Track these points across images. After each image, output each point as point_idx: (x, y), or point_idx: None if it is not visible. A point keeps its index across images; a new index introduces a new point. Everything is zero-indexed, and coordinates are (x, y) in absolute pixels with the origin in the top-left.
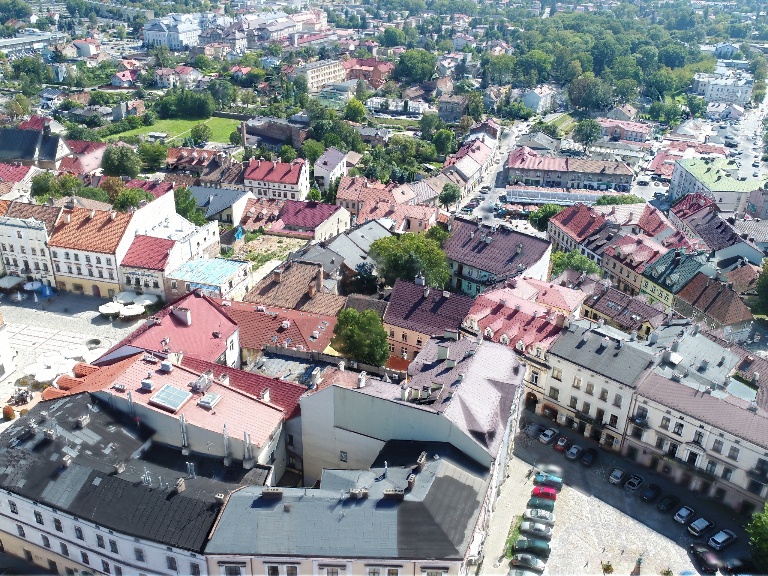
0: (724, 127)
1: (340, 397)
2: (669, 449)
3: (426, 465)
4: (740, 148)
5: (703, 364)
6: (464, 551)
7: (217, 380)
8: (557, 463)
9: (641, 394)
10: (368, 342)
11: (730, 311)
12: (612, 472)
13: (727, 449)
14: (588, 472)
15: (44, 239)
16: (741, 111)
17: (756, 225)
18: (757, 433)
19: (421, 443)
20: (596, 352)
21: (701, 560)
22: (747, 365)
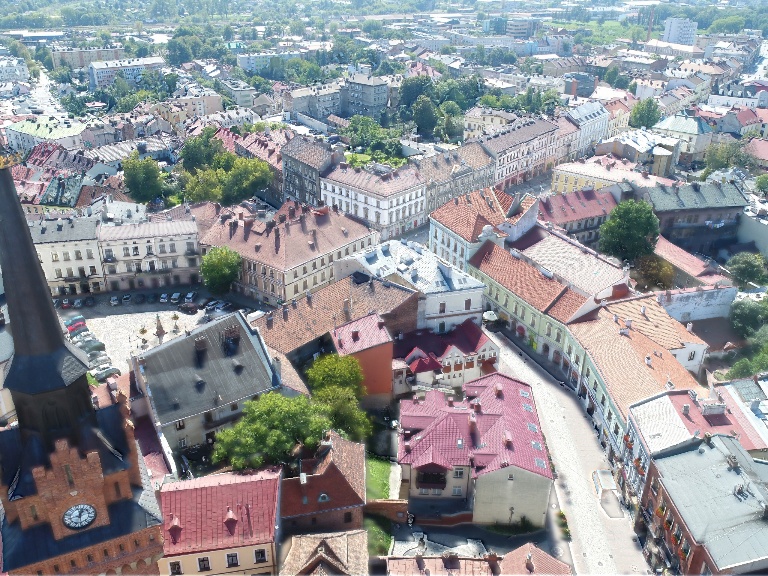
0: (23, 100)
1: None
2: (136, 268)
3: (2, 308)
4: (46, 114)
5: (128, 213)
6: (65, 329)
7: None
8: (71, 314)
9: (103, 241)
10: None
11: None
12: (110, 300)
13: (168, 247)
14: (95, 308)
15: None
16: (28, 86)
17: (99, 151)
18: (179, 230)
19: None
20: (58, 231)
21: (187, 309)
22: (149, 221)
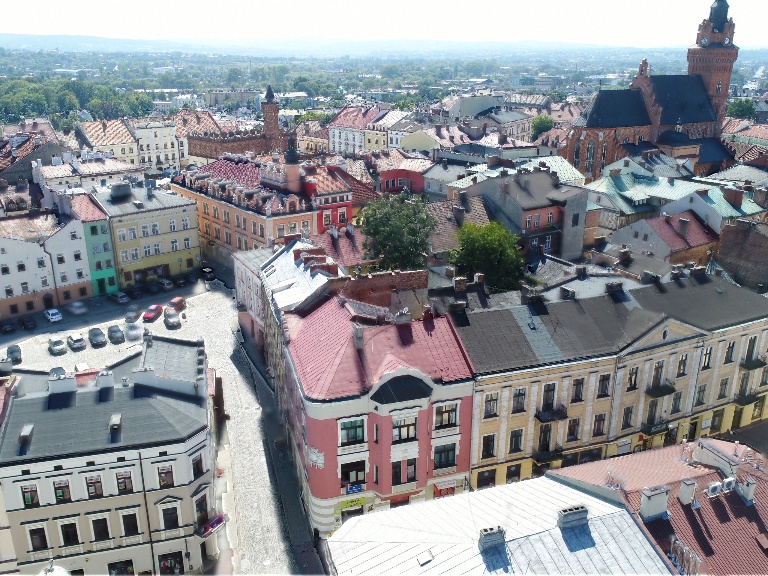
0: (225, 116)
1: (462, 102)
2: None
3: None
4: None
5: None
6: None
7: None
8: None
9: None
10: None
11: None
12: None
13: None
14: None
15: (175, 134)
16: (213, 111)
17: None
18: None
19: (486, 110)
20: None
21: None
22: None
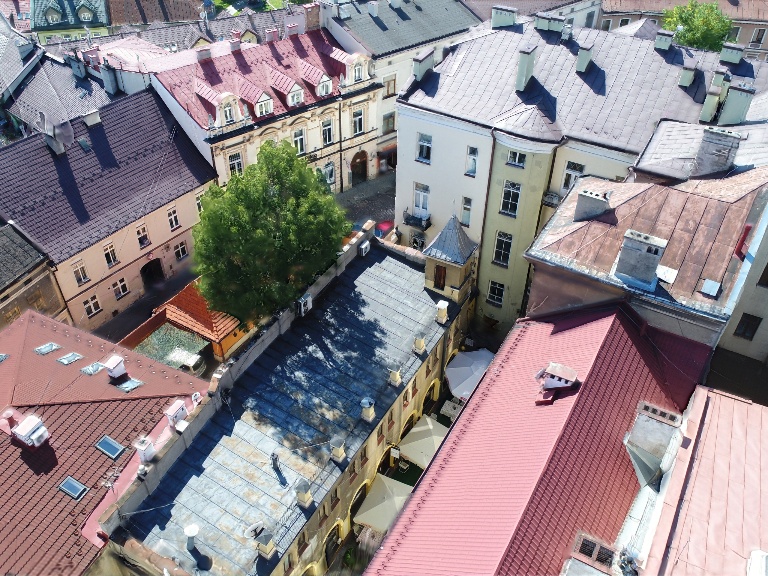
0: None
1: None
2: None
3: None
4: None
5: None
6: None
7: (643, 575)
8: None
9: None
10: (338, 211)
11: (191, 3)
12: None
13: None
14: None
15: None
16: None
17: None
18: None
19: None
20: (404, 19)
21: None
22: None
